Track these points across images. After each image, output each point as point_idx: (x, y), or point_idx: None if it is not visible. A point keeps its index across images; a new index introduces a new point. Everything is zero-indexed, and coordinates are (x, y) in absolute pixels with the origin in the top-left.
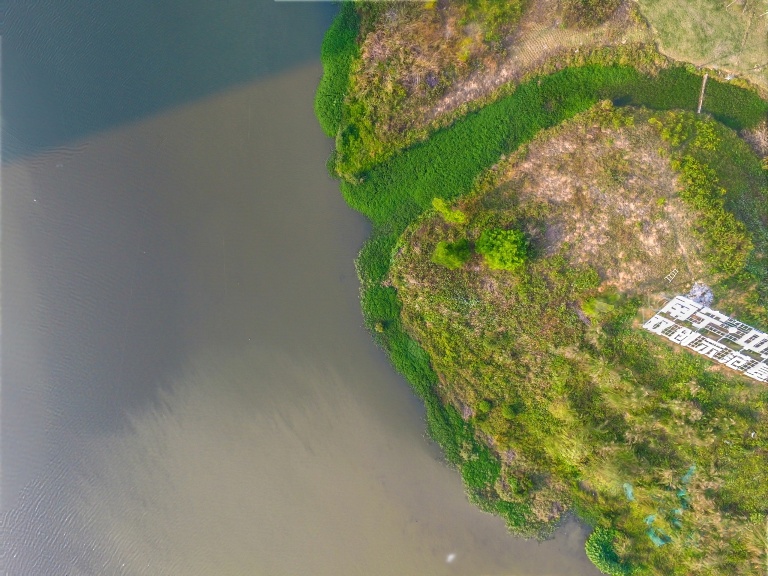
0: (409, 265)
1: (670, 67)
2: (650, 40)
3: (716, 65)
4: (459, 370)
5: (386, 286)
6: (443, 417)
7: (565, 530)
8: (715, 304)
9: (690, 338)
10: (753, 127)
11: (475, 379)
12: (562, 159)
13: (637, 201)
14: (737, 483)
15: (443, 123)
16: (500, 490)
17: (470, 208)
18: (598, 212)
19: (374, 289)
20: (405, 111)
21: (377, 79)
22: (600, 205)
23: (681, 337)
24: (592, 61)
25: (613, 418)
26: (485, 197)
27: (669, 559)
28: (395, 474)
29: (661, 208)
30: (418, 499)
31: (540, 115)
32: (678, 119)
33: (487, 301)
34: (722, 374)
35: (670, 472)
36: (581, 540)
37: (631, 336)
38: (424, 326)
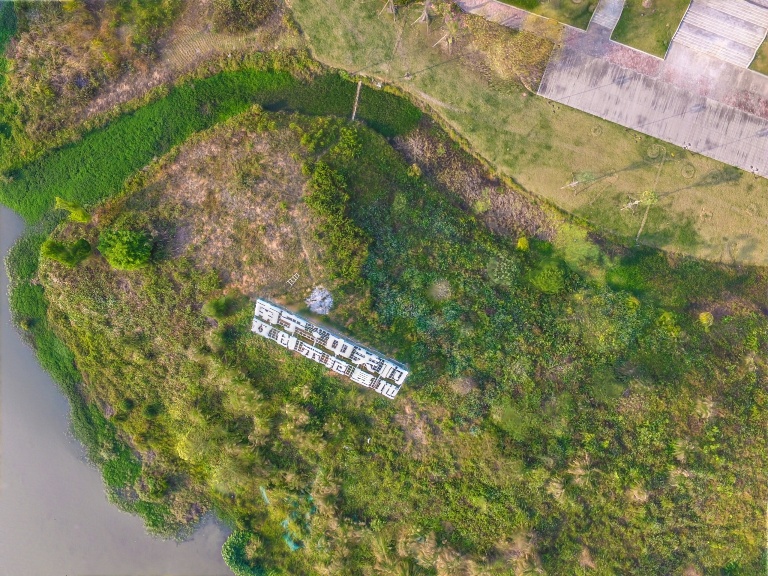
0: (53, 264)
1: (325, 73)
2: (303, 46)
3: (368, 72)
4: (101, 369)
5: (34, 284)
6: (85, 416)
7: (204, 532)
8: (334, 309)
9: (292, 342)
10: (406, 134)
11: (117, 379)
12: (204, 162)
13: (263, 205)
14: (359, 488)
15: (95, 124)
16: (138, 490)
17: (114, 208)
18: (225, 215)
19: (22, 287)
20: (56, 111)
21: (28, 79)
22: (227, 208)
23: (285, 341)
24: (246, 66)
25: (243, 421)
26: (131, 198)
27: (304, 563)
28: (36, 472)
29: (286, 212)
30: (59, 497)
31: (194, 118)
32: (323, 125)
33: (123, 301)
34: (338, 379)
35: (292, 476)
36: (220, 542)
37: (252, 339)
38: (69, 325)
